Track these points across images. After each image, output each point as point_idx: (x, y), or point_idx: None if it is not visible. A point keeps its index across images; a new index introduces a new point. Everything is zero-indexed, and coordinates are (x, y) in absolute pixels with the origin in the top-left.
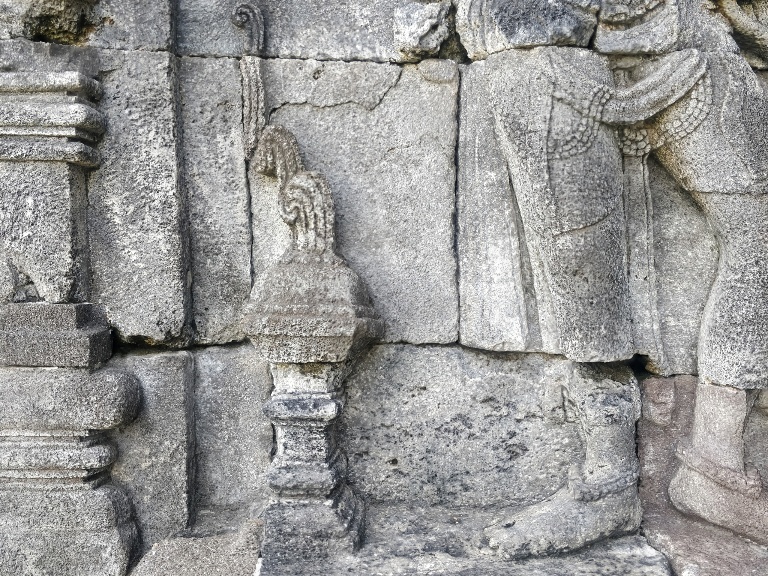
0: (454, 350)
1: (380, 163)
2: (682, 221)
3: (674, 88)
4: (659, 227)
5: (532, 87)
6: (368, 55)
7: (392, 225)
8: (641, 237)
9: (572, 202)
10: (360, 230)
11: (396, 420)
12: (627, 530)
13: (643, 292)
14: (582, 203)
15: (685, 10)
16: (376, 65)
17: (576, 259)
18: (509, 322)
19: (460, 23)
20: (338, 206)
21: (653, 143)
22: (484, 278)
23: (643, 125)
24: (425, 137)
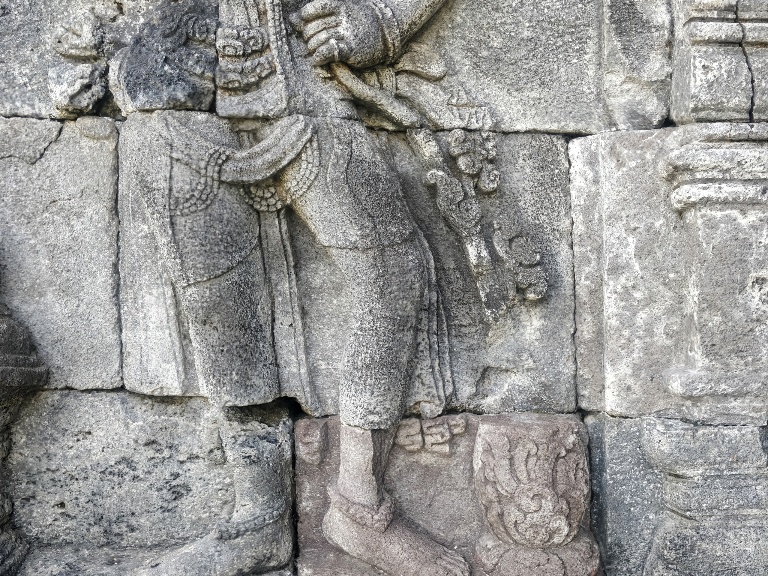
0: (119, 395)
1: (42, 215)
2: (327, 271)
3: (285, 150)
4: (306, 277)
5: (153, 148)
6: (27, 111)
7: (55, 275)
8: (283, 287)
9: (195, 256)
10: (23, 280)
11: (61, 464)
12: (271, 566)
13: (288, 338)
14: (204, 257)
15: (294, 79)
16: (36, 121)
17: (203, 309)
18: (165, 368)
19: (110, 83)
20: (1, 257)
21: (284, 199)
22: (141, 326)
23: (272, 183)
24: (86, 190)
